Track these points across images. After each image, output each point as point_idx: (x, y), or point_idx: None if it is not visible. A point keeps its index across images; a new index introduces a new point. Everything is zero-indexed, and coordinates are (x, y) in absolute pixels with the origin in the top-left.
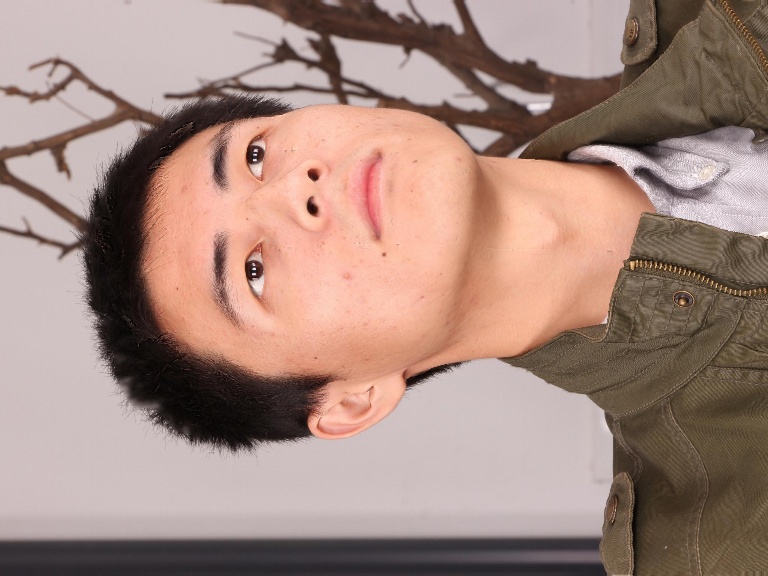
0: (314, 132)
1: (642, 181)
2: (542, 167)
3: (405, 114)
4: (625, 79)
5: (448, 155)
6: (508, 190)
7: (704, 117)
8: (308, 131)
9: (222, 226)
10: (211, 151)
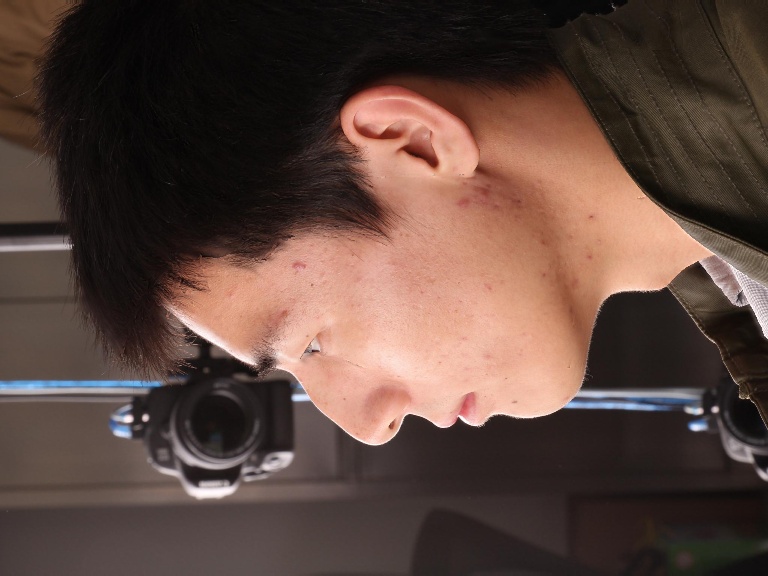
0: None
1: None
2: (652, 216)
3: (494, 318)
4: None
5: (554, 401)
6: (610, 275)
7: None
8: None
9: None
10: (253, 358)
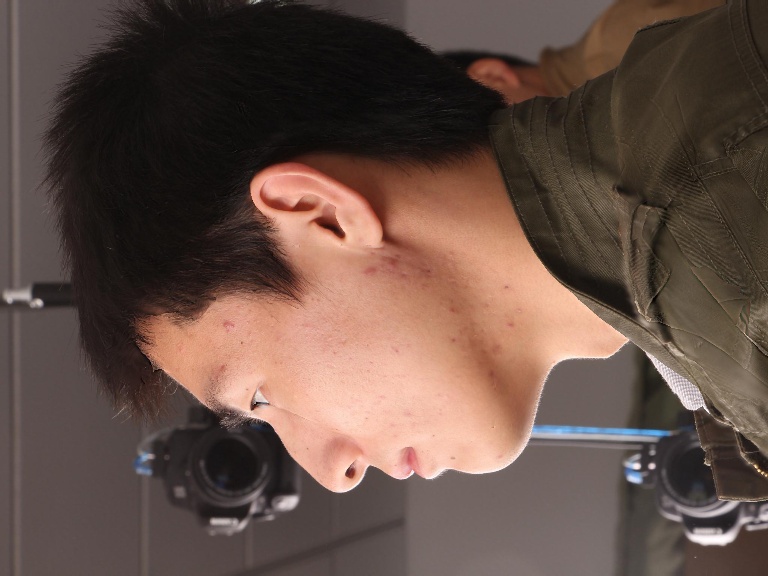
0: None
1: None
2: (565, 288)
3: (406, 379)
4: (626, 176)
5: (487, 459)
6: (542, 342)
7: (759, 406)
8: None
9: None
10: None
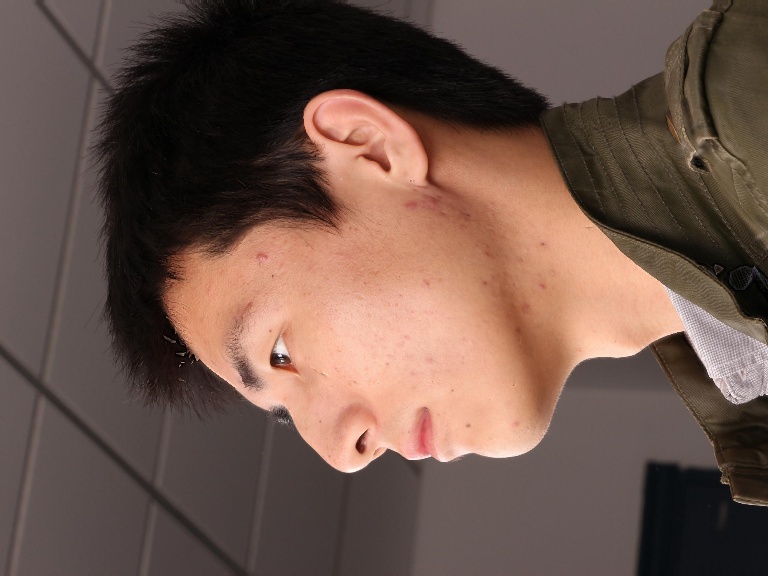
0: (340, 369)
1: (726, 382)
2: (601, 249)
3: (433, 316)
4: None
5: (503, 424)
6: (571, 317)
7: None
8: (333, 365)
9: (274, 404)
10: (230, 361)
